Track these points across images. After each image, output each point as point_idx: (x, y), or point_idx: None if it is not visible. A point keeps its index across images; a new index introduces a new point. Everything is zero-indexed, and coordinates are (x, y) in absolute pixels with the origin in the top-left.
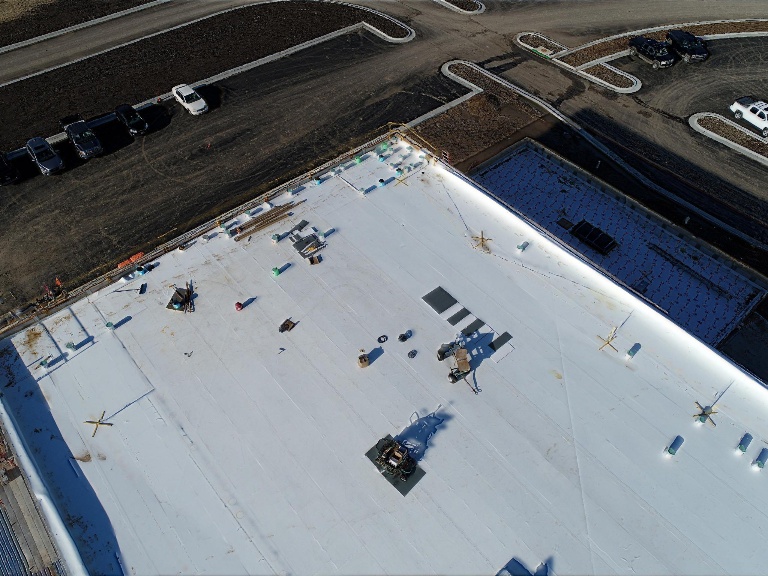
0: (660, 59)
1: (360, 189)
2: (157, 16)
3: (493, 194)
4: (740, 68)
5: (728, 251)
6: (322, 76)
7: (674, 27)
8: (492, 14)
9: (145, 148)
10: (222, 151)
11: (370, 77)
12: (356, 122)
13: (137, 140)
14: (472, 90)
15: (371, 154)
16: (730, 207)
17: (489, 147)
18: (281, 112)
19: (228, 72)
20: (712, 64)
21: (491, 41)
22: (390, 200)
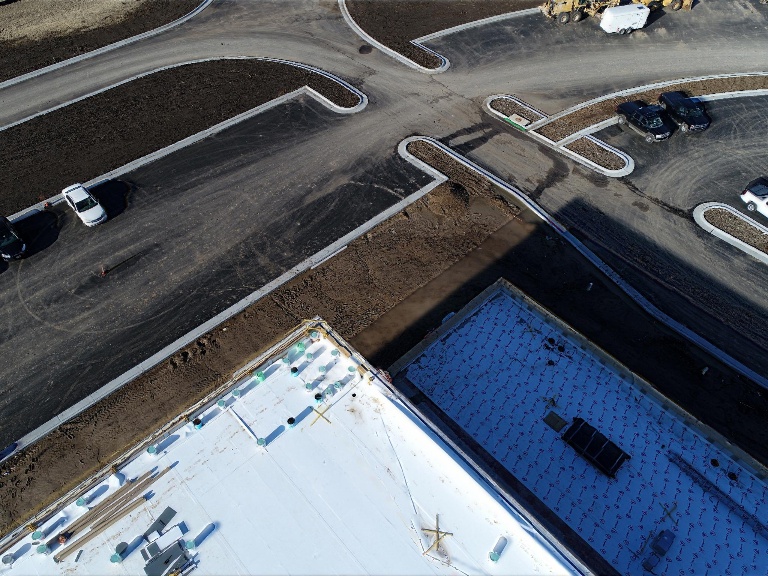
0: (655, 132)
1: (258, 441)
2: (59, 83)
3: (453, 443)
4: (746, 139)
5: (759, 416)
6: (253, 163)
7: (666, 85)
8: (457, 72)
9: (20, 278)
10: (120, 279)
11: (312, 163)
12: (292, 229)
13: (11, 266)
14: (434, 178)
15: (281, 362)
16: (754, 344)
17: (455, 263)
18: (200, 217)
19: (138, 161)
20: (714, 134)
21: (457, 108)
22: (303, 455)
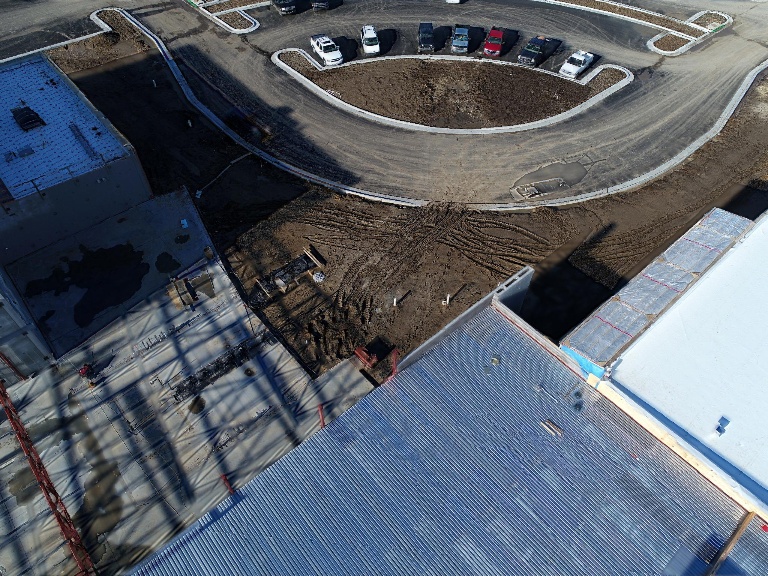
0: (281, 6)
1: None
2: None
3: None
4: (356, 15)
5: (208, 146)
6: None
7: None
8: None
9: None
10: None
11: (22, 19)
12: None
13: None
14: (103, 30)
15: None
16: (245, 116)
17: (76, 71)
18: None
19: None
20: (335, 12)
21: None
22: None
